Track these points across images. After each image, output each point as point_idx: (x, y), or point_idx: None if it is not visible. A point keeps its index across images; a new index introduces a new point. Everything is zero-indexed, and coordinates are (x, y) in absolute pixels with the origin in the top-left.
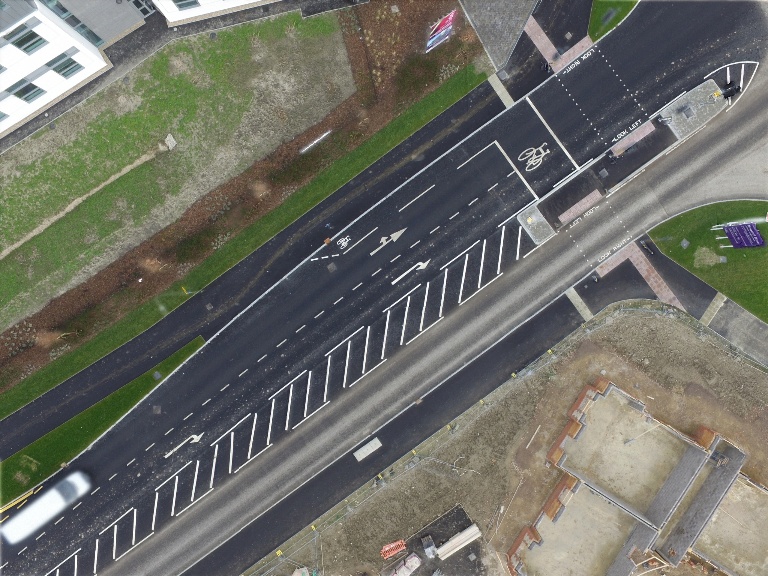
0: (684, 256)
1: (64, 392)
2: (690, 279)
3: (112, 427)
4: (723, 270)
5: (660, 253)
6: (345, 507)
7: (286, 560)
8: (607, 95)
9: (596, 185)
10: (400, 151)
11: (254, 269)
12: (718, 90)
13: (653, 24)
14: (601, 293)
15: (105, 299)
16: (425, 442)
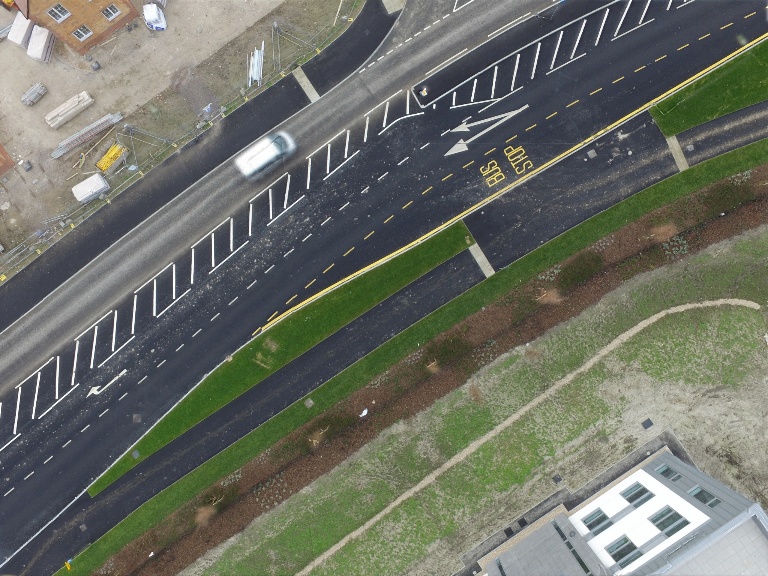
0: None
1: (229, 435)
2: None
3: (182, 399)
4: None
5: None
6: None
7: None
8: None
9: None
10: None
11: (38, 568)
12: None
13: None
14: None
15: (188, 534)
16: None
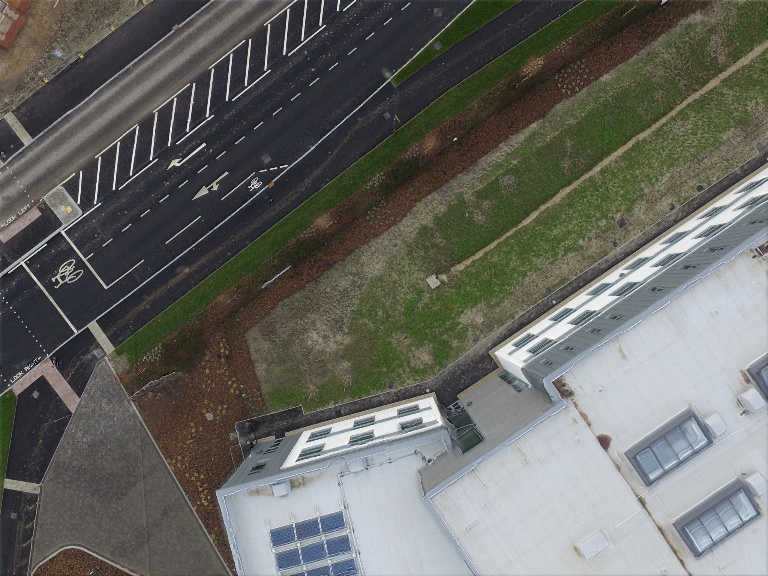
0: None
1: (530, 26)
2: None
3: None
4: None
5: None
6: None
7: None
8: None
9: (4, 247)
10: (200, 275)
11: (343, 154)
12: None
13: None
14: None
15: (490, 120)
16: None
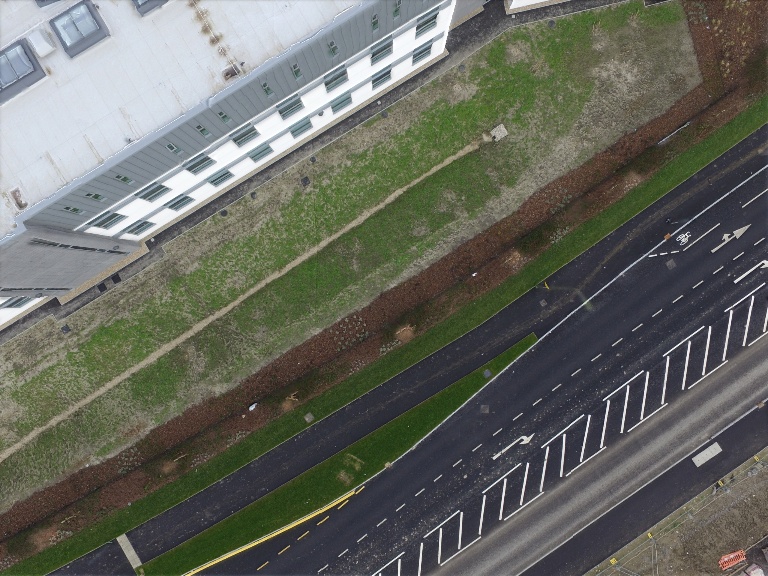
0: None
1: (391, 389)
2: None
3: (438, 426)
4: None
5: None
6: (683, 514)
7: (621, 569)
8: None
9: None
10: (747, 145)
11: (591, 265)
12: None
13: None
14: None
15: (437, 293)
16: (767, 448)
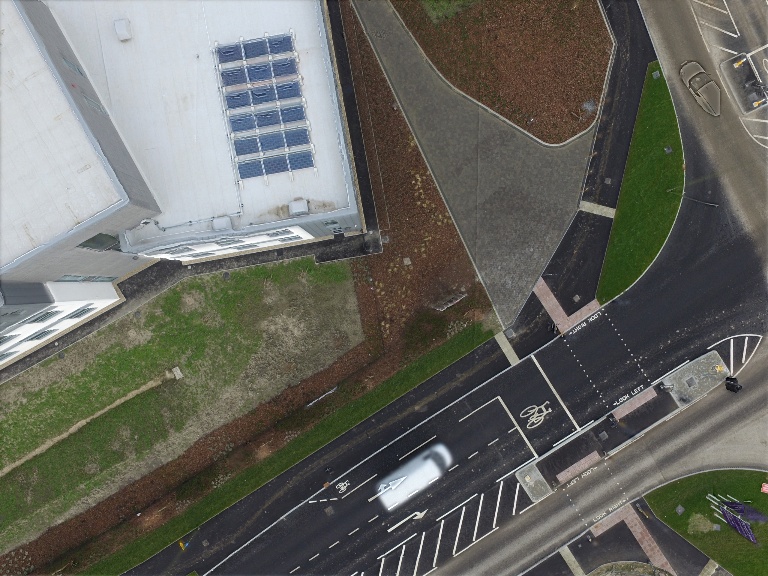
0: (678, 522)
1: None
2: (683, 545)
3: None
4: (716, 538)
5: (655, 517)
6: None
7: None
8: (611, 358)
9: (595, 447)
10: (404, 402)
11: (252, 509)
12: (721, 362)
13: (660, 292)
14: (594, 553)
15: (102, 531)
16: None
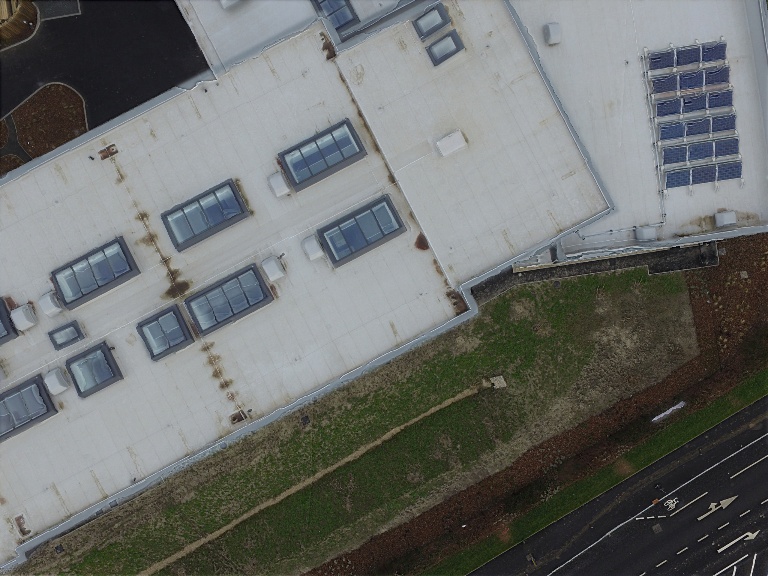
0: None
1: None
2: None
3: None
4: None
5: None
6: None
7: None
8: None
9: None
10: (739, 418)
11: (579, 524)
12: None
13: None
14: None
15: (426, 541)
16: None
